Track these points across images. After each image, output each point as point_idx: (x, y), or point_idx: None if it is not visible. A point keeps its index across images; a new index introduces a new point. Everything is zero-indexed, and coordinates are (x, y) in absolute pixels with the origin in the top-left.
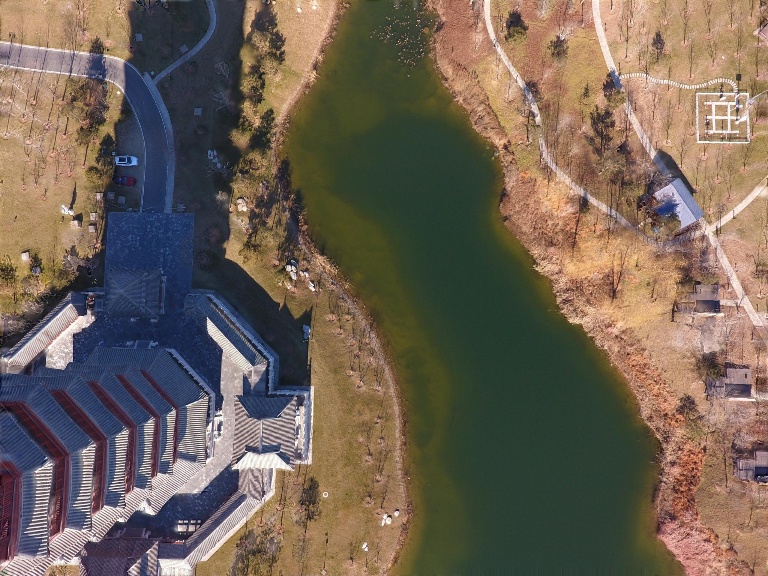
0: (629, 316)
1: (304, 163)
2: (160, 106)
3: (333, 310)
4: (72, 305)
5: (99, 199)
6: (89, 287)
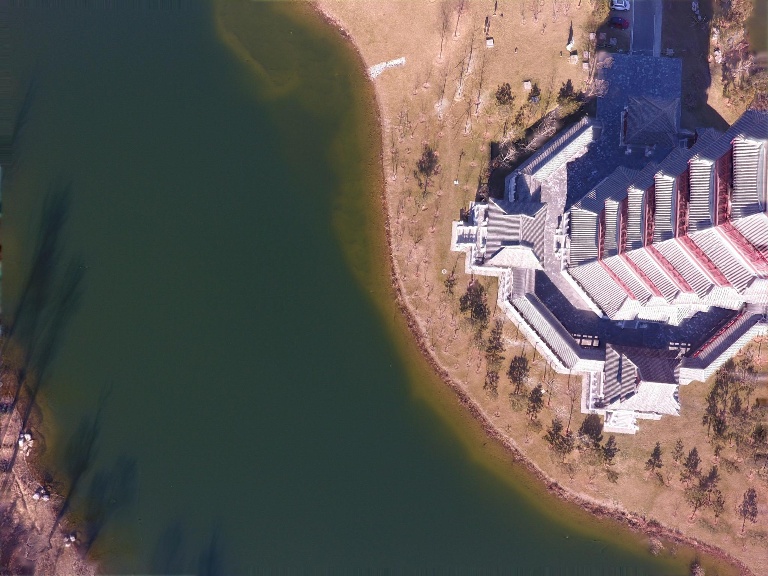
0: None
1: (758, 28)
2: None
3: None
4: (591, 128)
5: (592, 39)
6: (576, 122)
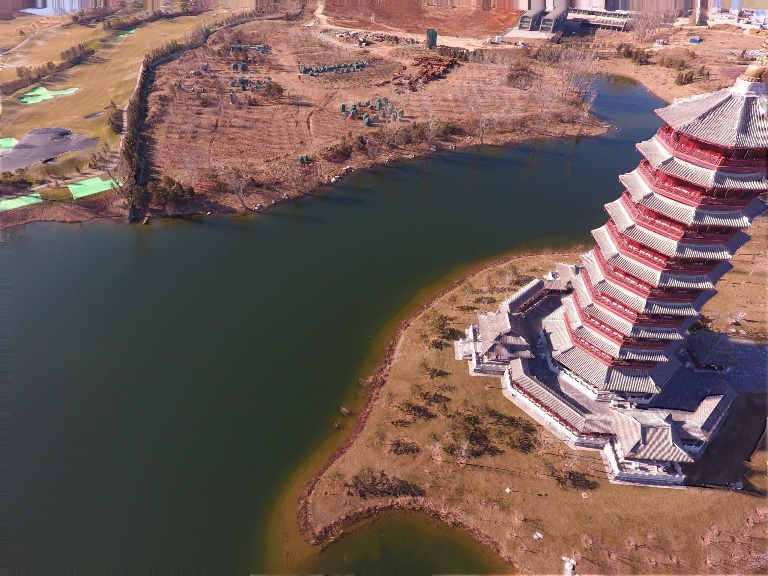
0: None
1: None
2: None
3: (767, 517)
4: None
5: (759, 335)
6: None
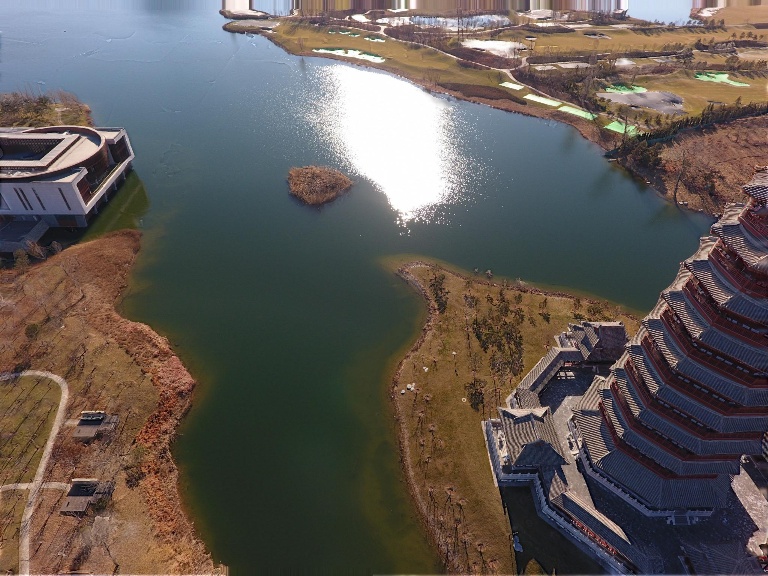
0: (161, 575)
1: None
2: None
3: (494, 575)
4: None
5: None
6: None
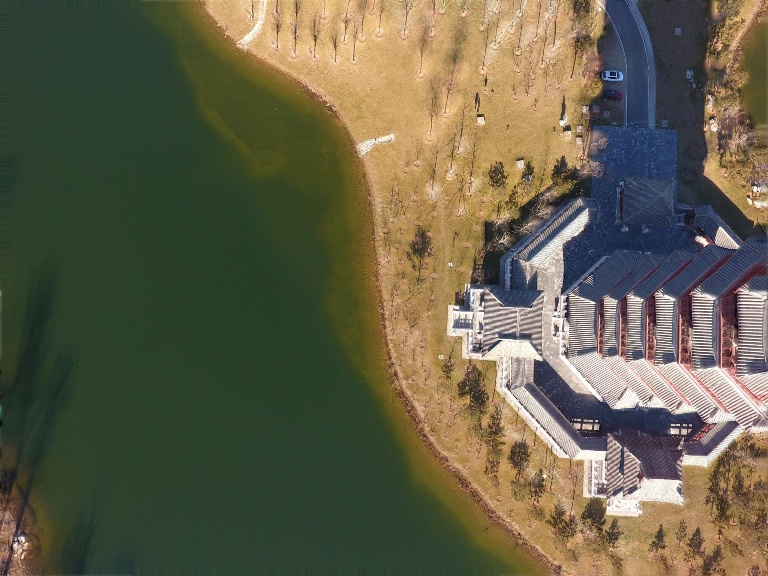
0: None
1: (753, 90)
2: (640, 25)
3: None
4: (587, 210)
5: (585, 112)
6: (571, 198)
